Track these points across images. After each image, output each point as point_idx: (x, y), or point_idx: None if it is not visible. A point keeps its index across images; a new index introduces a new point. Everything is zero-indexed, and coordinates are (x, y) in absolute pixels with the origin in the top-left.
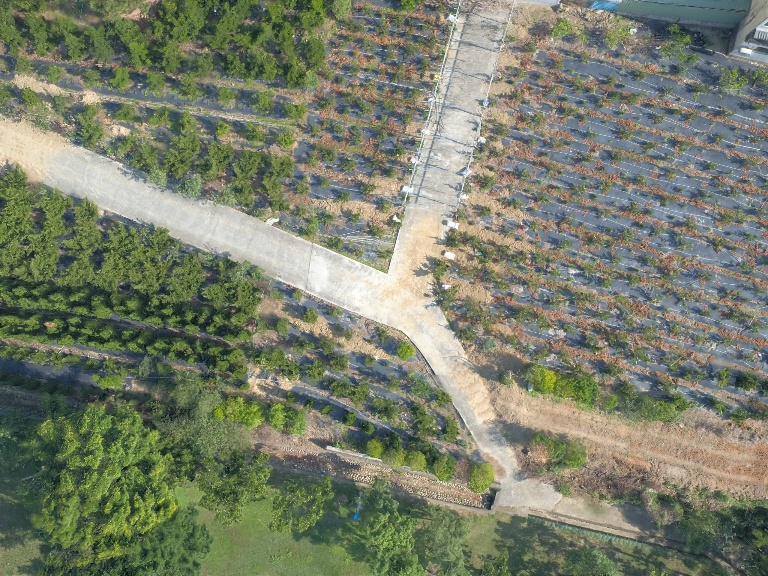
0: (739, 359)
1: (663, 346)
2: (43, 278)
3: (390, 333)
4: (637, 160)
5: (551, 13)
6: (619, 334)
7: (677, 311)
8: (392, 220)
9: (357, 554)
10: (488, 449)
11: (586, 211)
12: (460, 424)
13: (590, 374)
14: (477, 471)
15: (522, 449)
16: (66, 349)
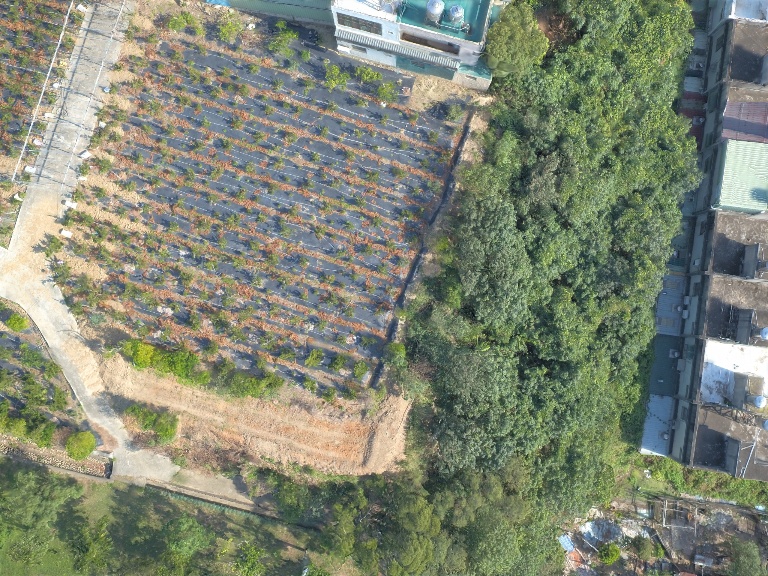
0: (335, 341)
1: (265, 327)
2: None
3: (9, 306)
4: (249, 149)
5: (176, 6)
6: None
7: (279, 294)
8: (14, 198)
9: None
10: (97, 420)
11: (198, 196)
12: (71, 395)
13: (194, 351)
14: (73, 439)
15: None
16: None
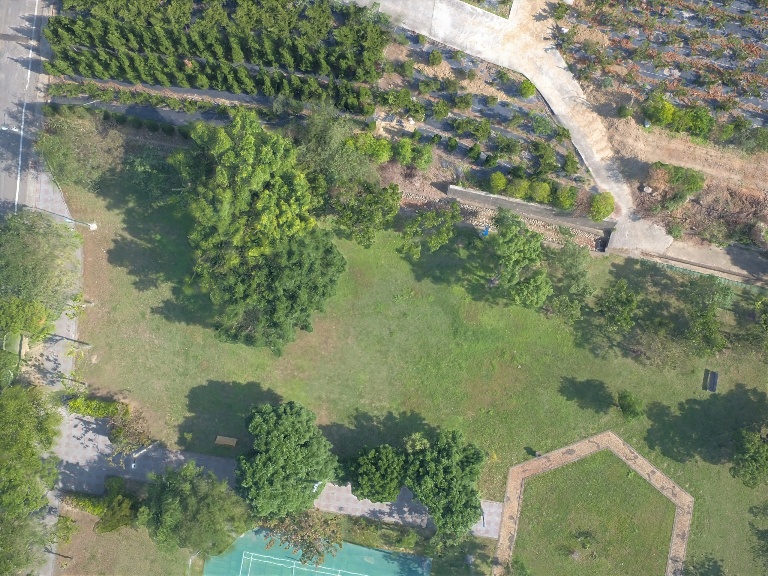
0: None
1: None
2: (178, 26)
3: (511, 76)
4: None
5: None
6: (733, 71)
7: None
8: None
9: (477, 294)
10: (606, 185)
11: None
12: (579, 162)
13: None
14: (599, 197)
15: (638, 186)
16: (198, 98)
